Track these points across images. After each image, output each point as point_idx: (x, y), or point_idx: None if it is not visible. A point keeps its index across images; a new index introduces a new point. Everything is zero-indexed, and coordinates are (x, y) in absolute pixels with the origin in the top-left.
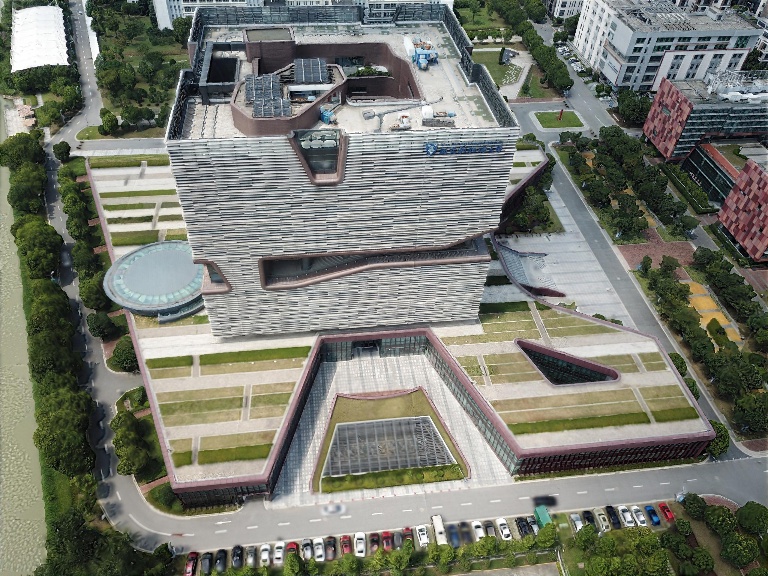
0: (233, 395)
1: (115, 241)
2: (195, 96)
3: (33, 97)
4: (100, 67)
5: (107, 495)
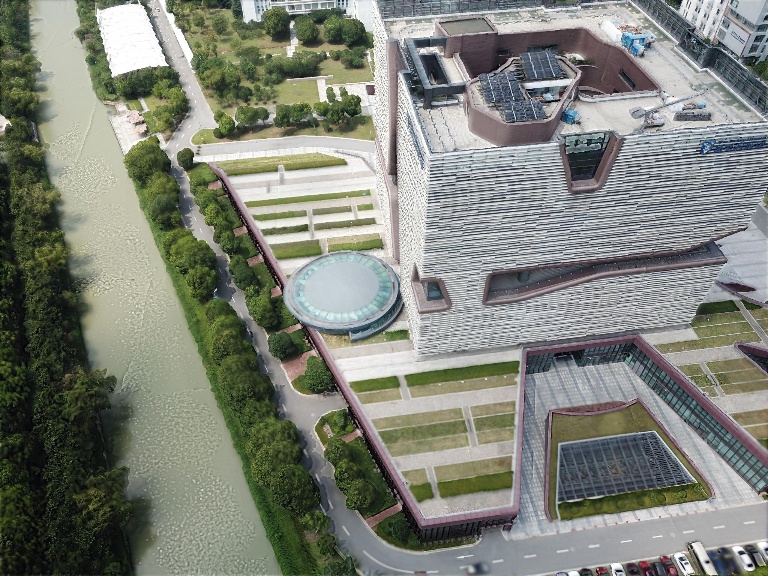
0: (453, 418)
1: (278, 254)
2: (415, 100)
3: (136, 101)
4: (201, 66)
5: (334, 530)
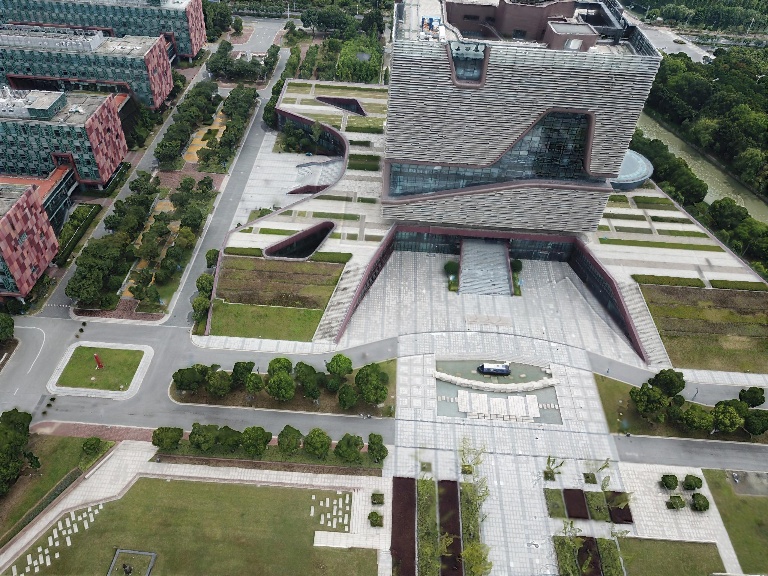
0: None
1: (669, 201)
2: None
3: None
4: None
5: None
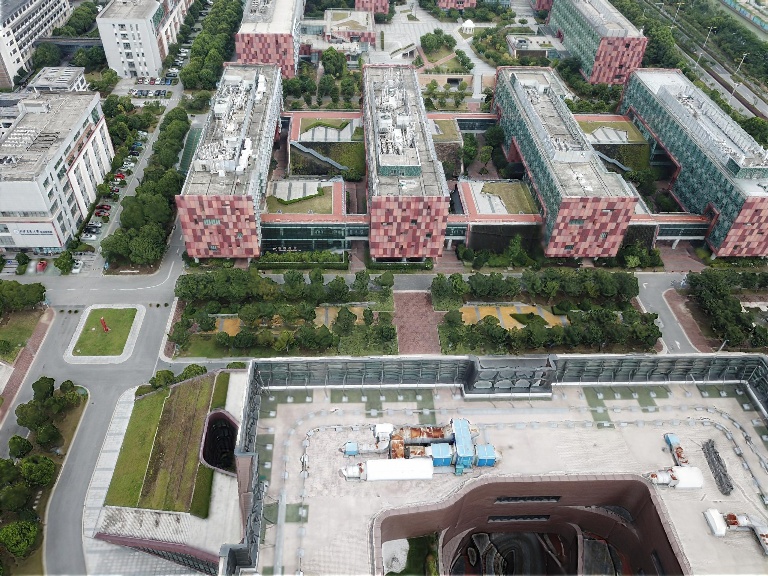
0: None
1: None
2: None
3: None
4: None
5: None
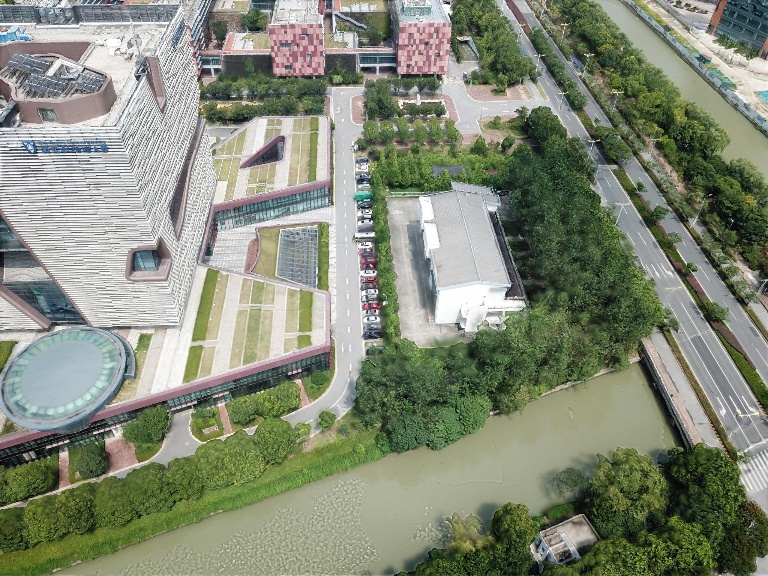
0: (246, 316)
1: None
2: None
3: None
4: None
5: None
